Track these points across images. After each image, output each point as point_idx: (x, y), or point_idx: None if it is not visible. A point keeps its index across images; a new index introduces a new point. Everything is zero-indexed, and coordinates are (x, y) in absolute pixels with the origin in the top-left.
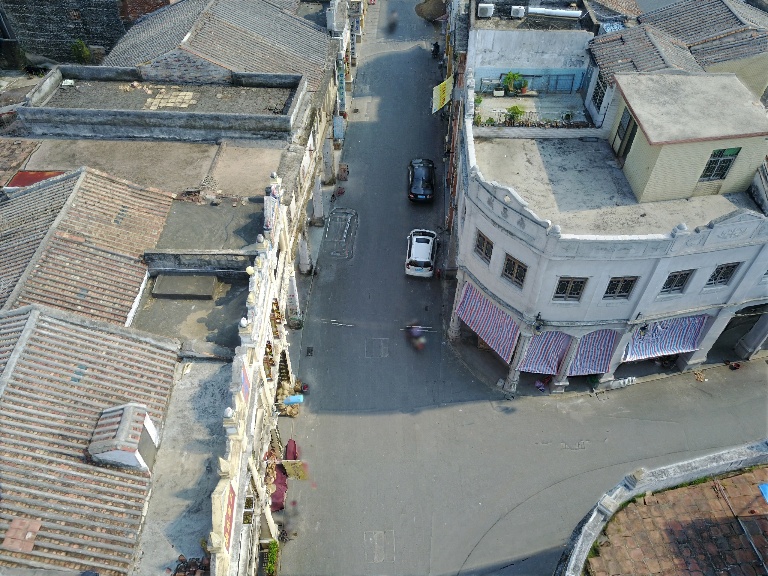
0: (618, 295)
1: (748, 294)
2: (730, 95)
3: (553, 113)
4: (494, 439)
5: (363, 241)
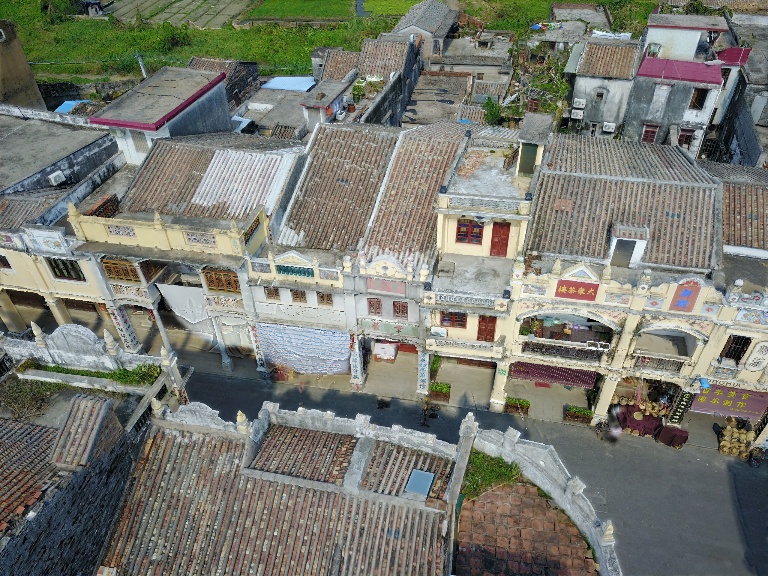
0: None
1: None
2: None
3: None
4: None
5: None
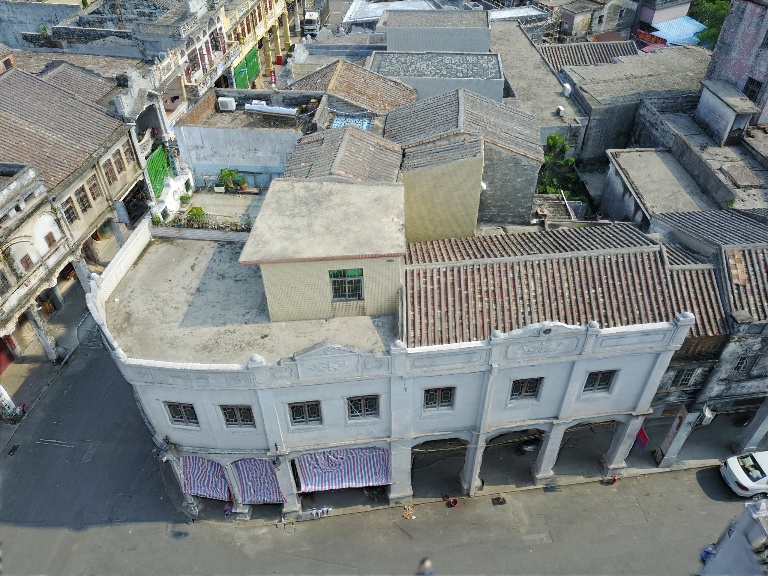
0: (243, 423)
1: (419, 428)
2: (376, 208)
3: (230, 216)
4: (147, 571)
5: None
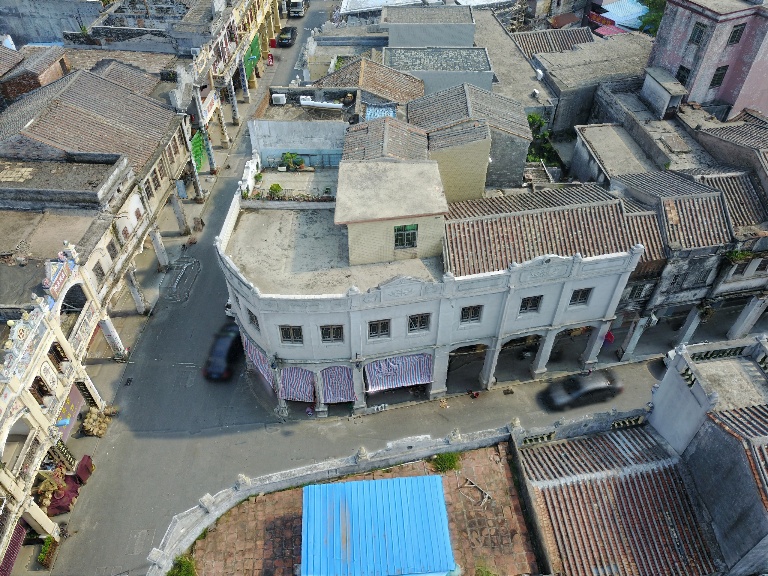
0: (334, 339)
1: (455, 337)
2: (422, 180)
3: (303, 190)
4: (258, 455)
5: (200, 286)
